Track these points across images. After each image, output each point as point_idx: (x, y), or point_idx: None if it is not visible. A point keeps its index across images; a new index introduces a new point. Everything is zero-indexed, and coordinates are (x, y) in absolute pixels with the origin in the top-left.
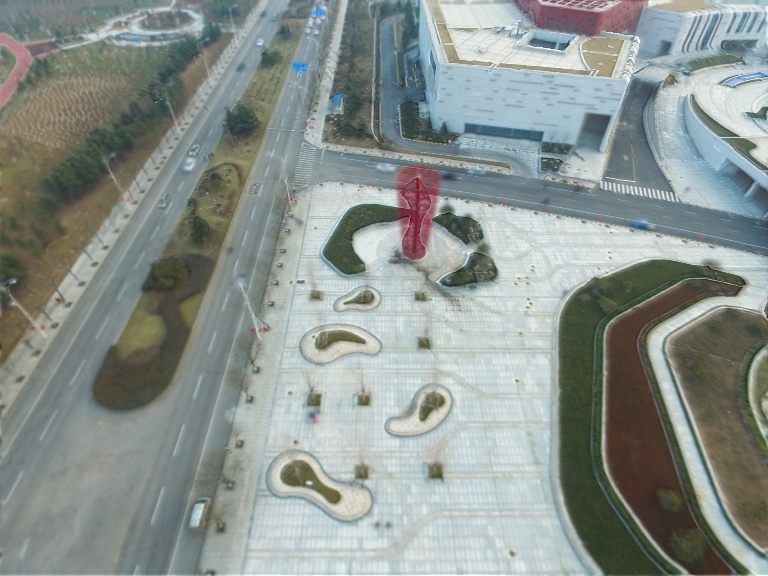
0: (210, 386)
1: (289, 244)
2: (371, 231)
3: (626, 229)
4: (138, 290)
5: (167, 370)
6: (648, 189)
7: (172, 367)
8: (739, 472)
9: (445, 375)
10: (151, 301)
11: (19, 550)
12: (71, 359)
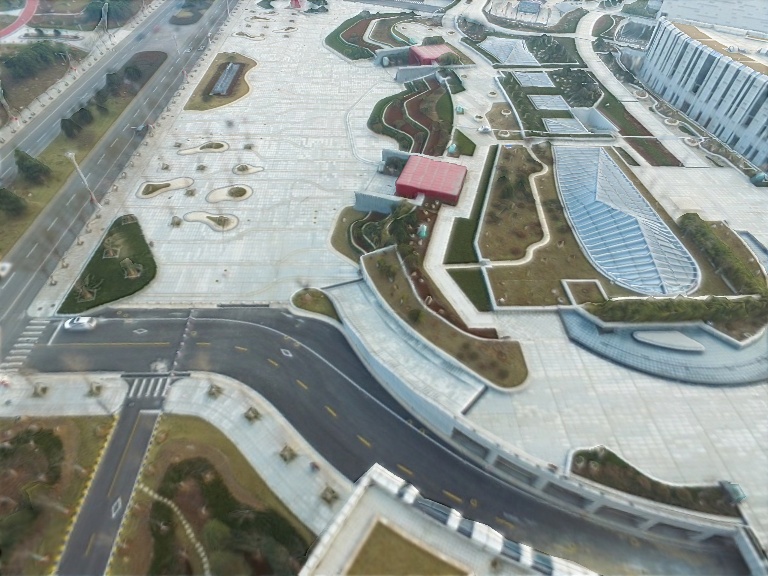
0: (211, 23)
1: (243, 3)
2: (279, 2)
3: (391, 7)
4: (180, 8)
5: (195, 19)
6: (412, 1)
7: (197, 19)
8: (379, 33)
9: (297, 26)
10: (186, 9)
11: (155, 39)
12: (159, 18)
